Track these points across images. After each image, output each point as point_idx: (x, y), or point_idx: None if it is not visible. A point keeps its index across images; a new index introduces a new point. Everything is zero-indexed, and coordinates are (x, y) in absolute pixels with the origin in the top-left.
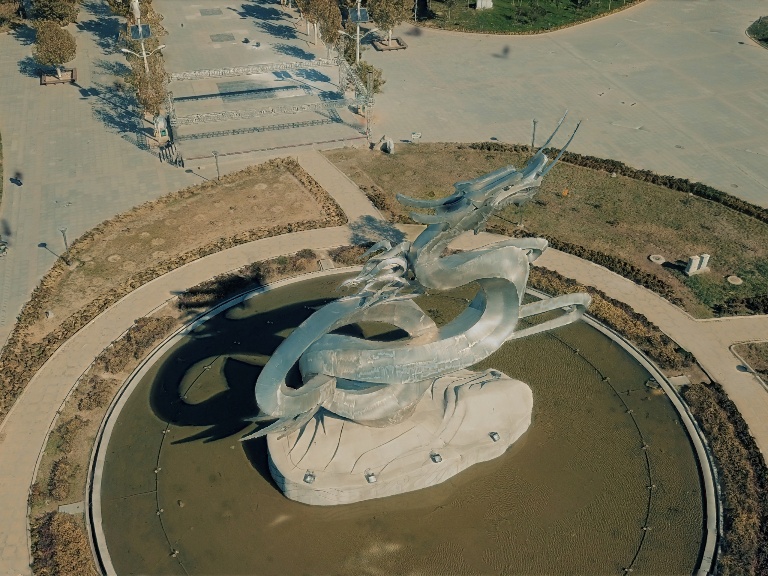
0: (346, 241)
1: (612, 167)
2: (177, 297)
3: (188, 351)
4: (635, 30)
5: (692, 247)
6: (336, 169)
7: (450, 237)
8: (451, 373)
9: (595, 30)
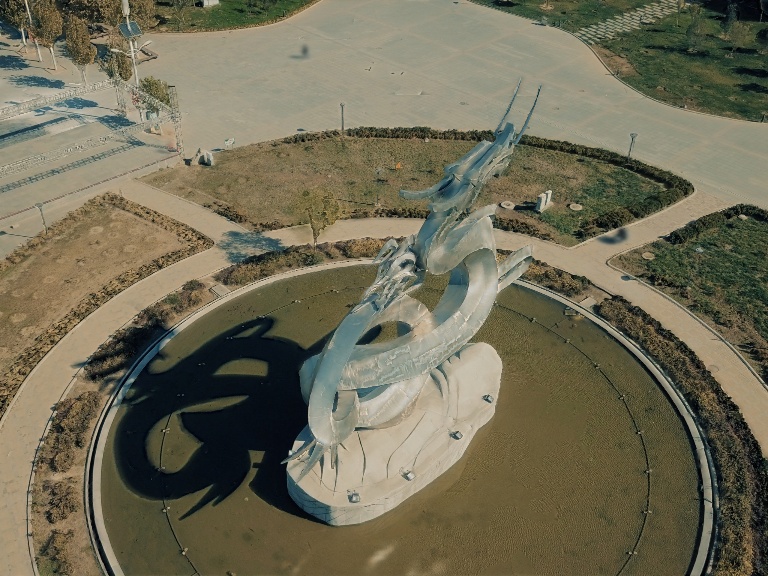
0: (225, 262)
1: (422, 133)
2: (83, 369)
3: (133, 421)
4: (361, 5)
5: (528, 188)
6: (166, 193)
7: (453, 220)
8: None
9: (326, 11)
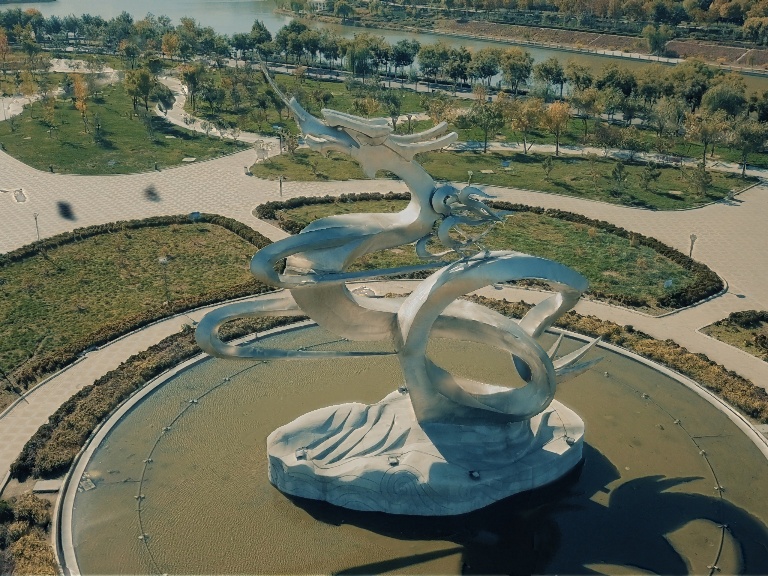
0: None
1: None
2: None
3: None
4: None
5: None
6: None
7: None
8: (359, 458)
9: None
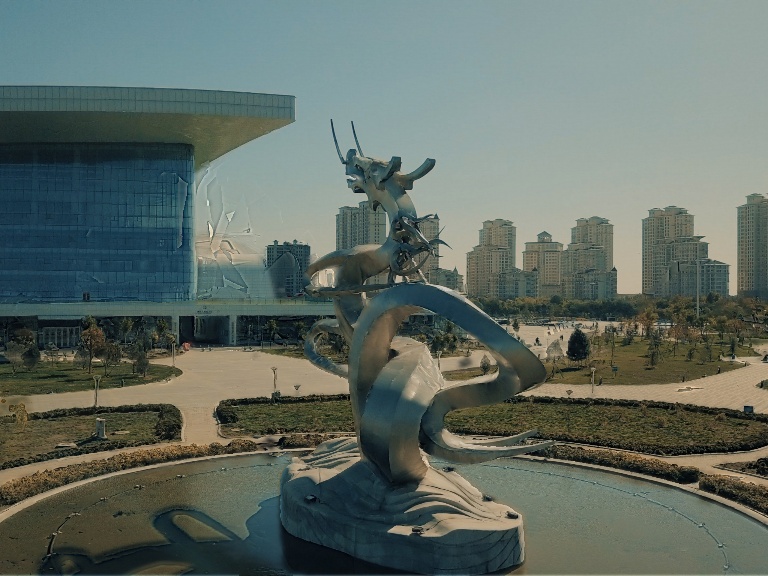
0: None
1: None
2: None
3: None
4: None
5: None
6: None
7: None
8: None
9: None
